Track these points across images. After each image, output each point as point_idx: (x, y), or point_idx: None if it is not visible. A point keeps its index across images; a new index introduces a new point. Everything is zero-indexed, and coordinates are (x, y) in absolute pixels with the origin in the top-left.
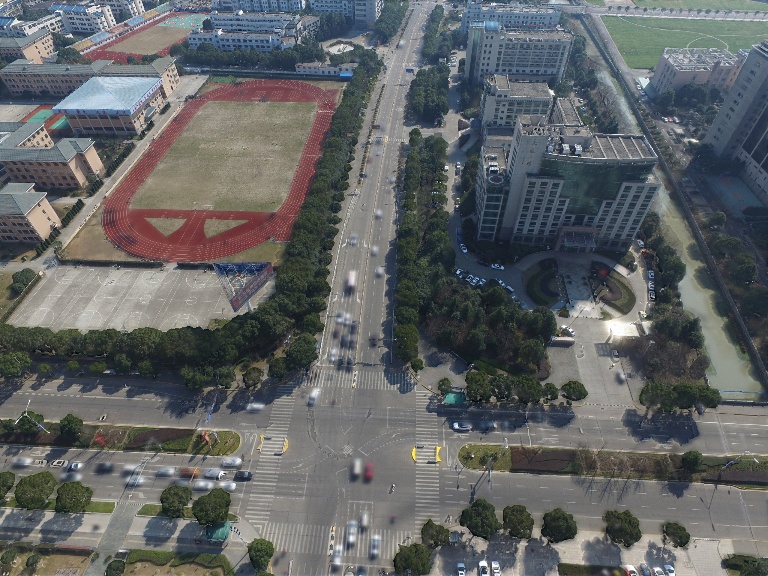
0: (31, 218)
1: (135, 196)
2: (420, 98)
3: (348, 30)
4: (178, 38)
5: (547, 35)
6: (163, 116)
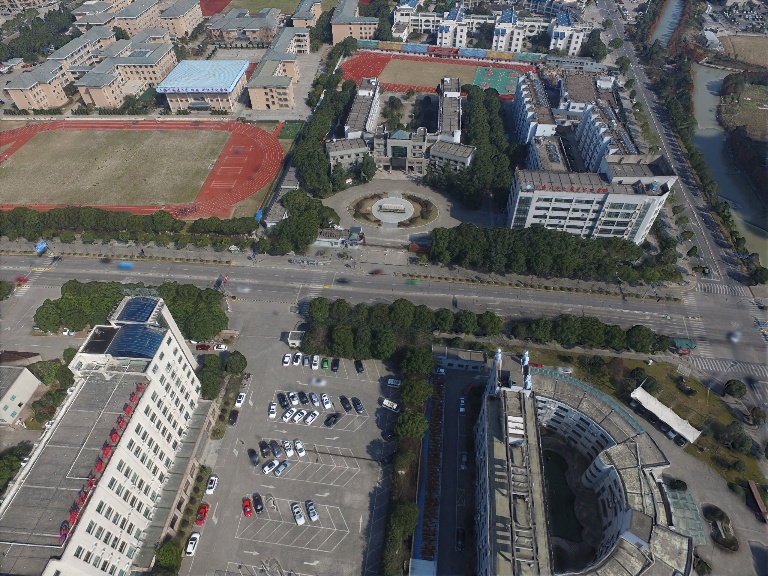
0: (12, 93)
1: (56, 131)
2: (83, 286)
3: (472, 206)
4: (433, 85)
5: (57, 489)
6: (207, 115)
